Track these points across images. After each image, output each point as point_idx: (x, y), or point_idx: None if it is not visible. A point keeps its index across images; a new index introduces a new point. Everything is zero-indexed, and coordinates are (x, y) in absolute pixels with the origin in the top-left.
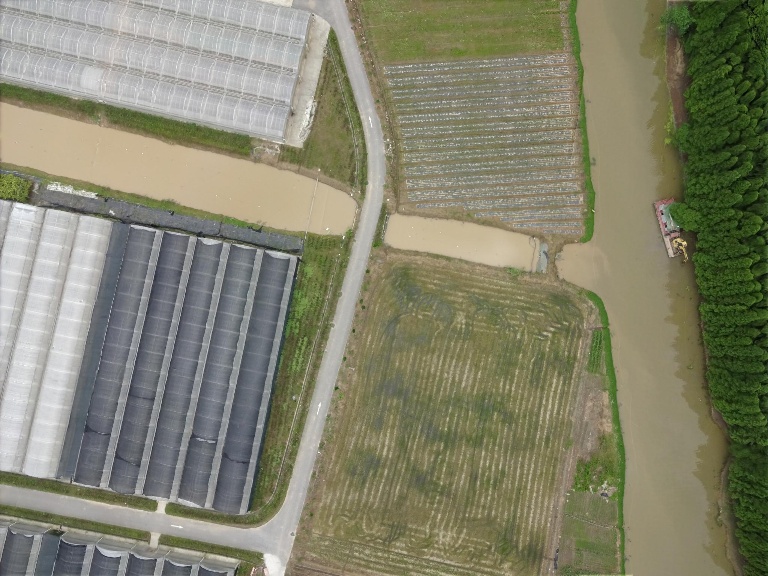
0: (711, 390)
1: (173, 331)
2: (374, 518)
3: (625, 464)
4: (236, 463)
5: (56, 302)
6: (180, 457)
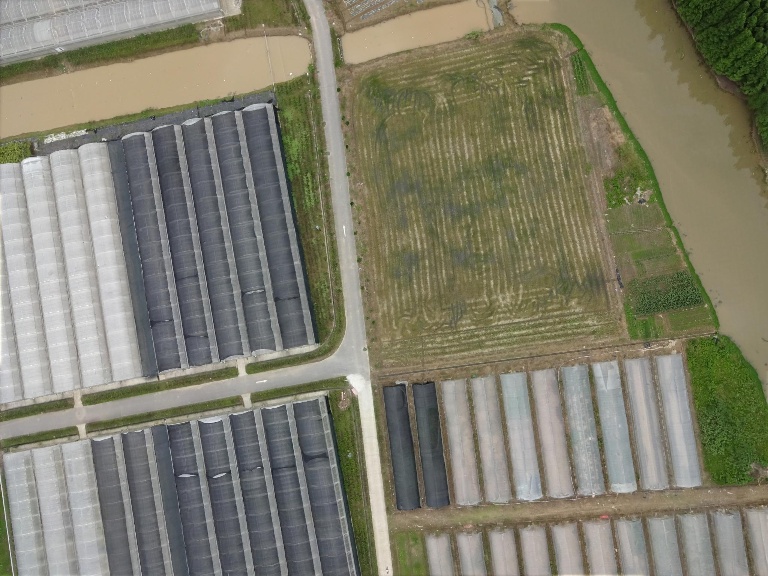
0: (707, 59)
1: (191, 212)
2: (433, 307)
3: (651, 166)
4: (288, 300)
5: (86, 229)
6: (239, 316)
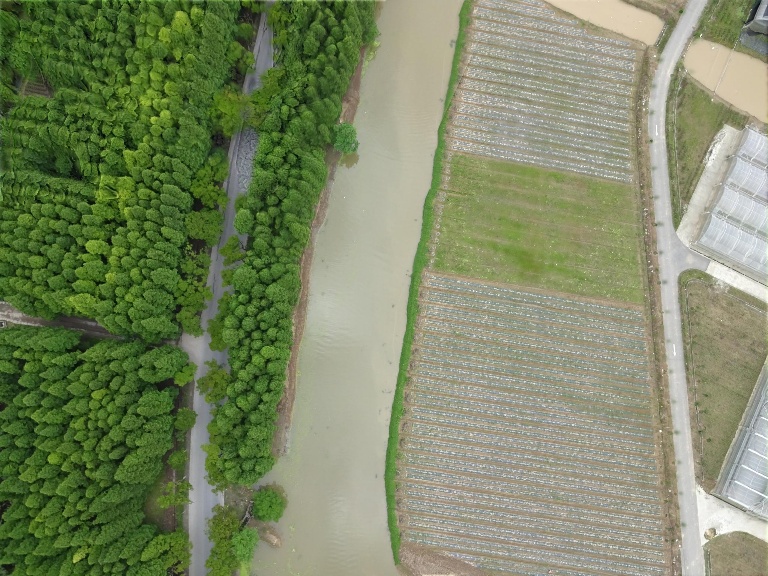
0: None
1: None
2: None
3: None
4: None
5: None
6: None
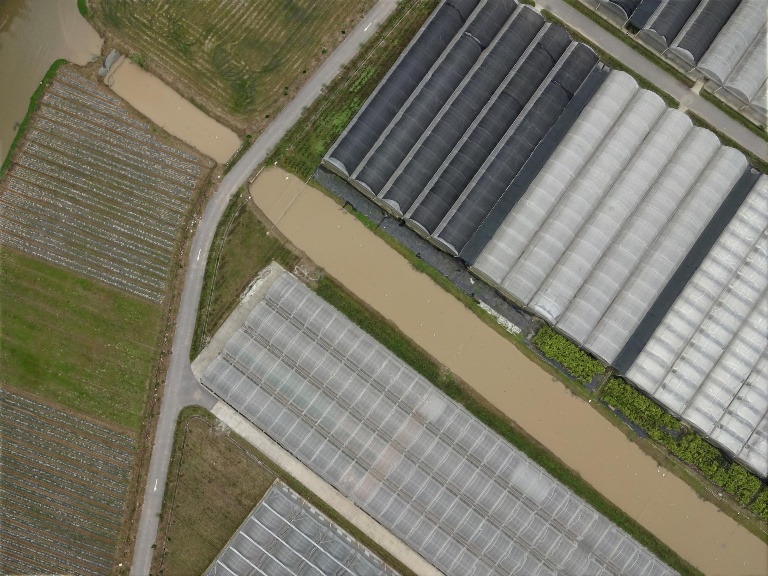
0: None
1: (461, 144)
2: None
3: None
4: (455, 7)
5: (552, 217)
6: (501, 35)
